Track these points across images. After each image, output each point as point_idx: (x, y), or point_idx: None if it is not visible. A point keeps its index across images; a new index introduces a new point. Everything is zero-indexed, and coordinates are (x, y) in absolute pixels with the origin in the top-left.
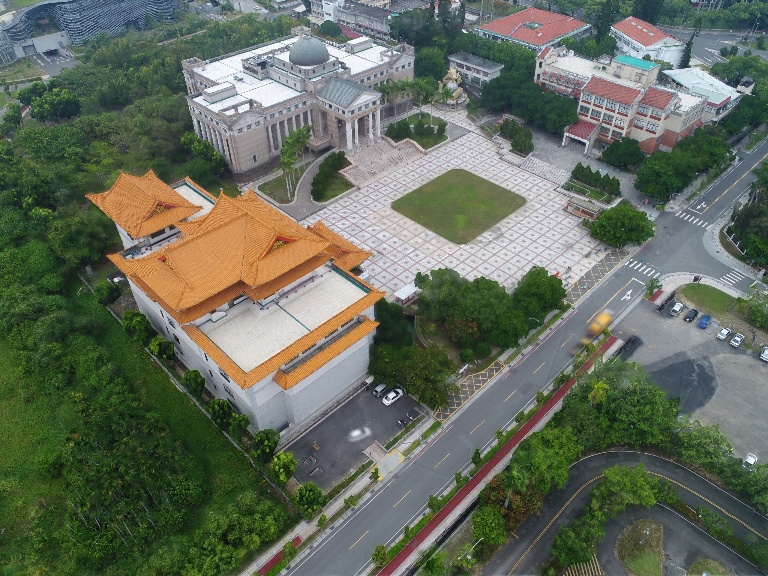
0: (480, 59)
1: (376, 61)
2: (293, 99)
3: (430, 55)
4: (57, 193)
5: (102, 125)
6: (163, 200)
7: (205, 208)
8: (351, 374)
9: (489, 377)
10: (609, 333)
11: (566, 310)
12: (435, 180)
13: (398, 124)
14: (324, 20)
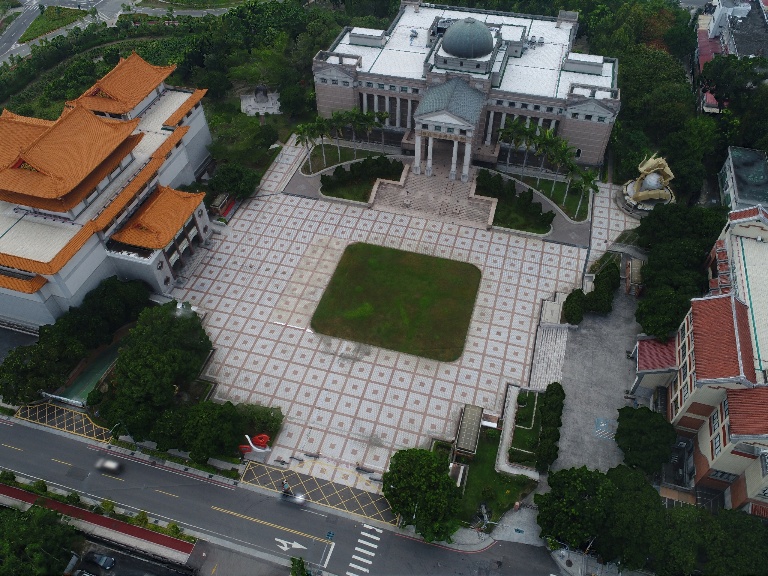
0: (767, 176)
1: (561, 91)
2: (400, 79)
3: (693, 128)
4: (205, 55)
5: (313, 22)
6: (113, 89)
7: (161, 119)
8: (36, 316)
9: (88, 433)
10: (192, 538)
11: (225, 475)
12: (434, 258)
13: None
14: (709, 25)
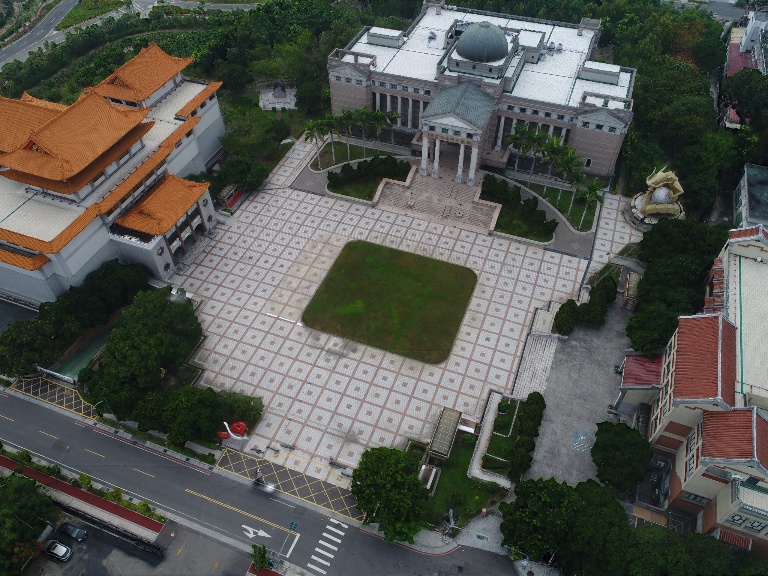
0: None
1: (574, 99)
2: (412, 80)
3: (709, 143)
4: (228, 49)
5: (337, 20)
6: (130, 78)
7: (175, 109)
8: (39, 293)
9: (76, 409)
10: (163, 518)
11: (201, 459)
12: (431, 260)
13: (500, 181)
14: (741, 39)
